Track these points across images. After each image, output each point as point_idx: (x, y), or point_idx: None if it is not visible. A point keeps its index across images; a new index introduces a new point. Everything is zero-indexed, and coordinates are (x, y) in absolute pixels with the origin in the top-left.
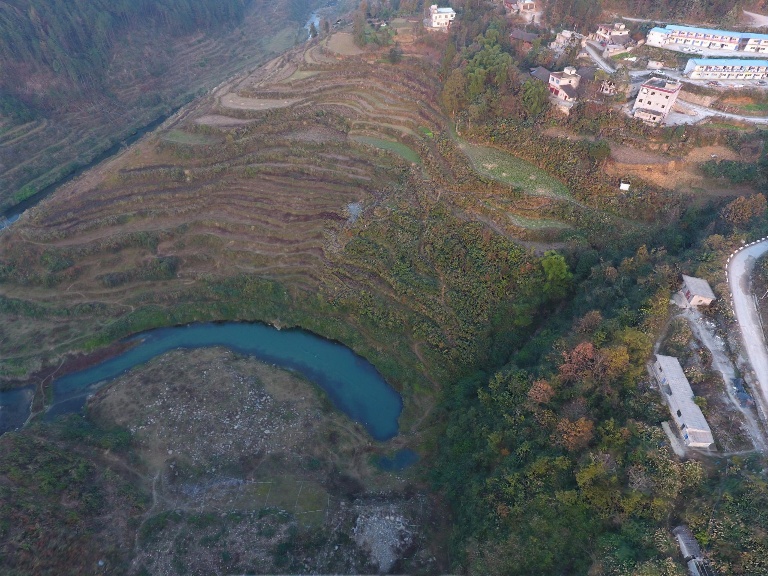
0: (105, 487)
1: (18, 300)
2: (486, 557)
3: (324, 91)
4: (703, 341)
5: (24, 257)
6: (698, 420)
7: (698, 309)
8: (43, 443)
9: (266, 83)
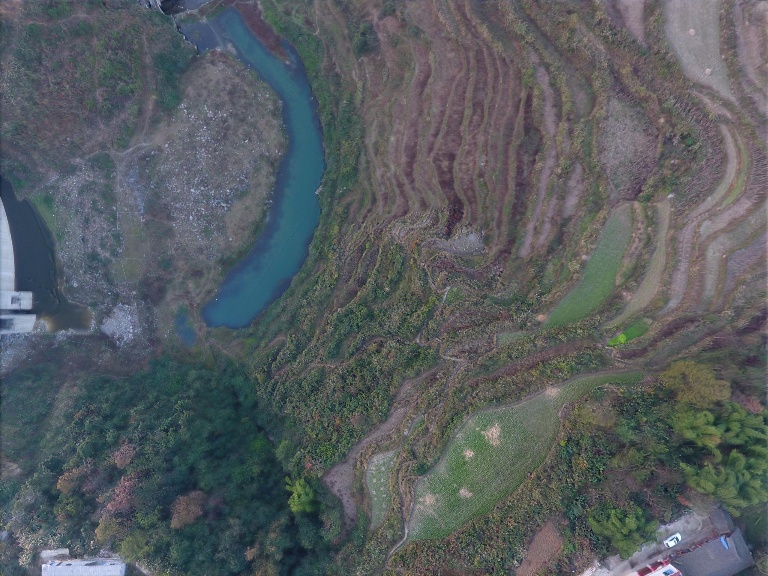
0: (122, 112)
1: None
2: None
3: None
4: None
5: None
6: None
7: None
8: (135, 48)
9: (767, 12)
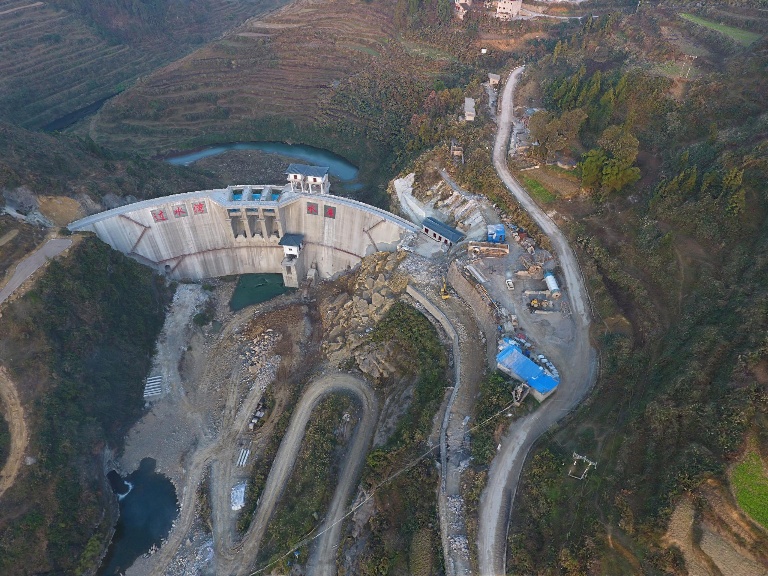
0: None
1: (138, 125)
2: (385, 184)
3: (321, 20)
4: (488, 93)
5: (139, 104)
6: (472, 111)
7: (493, 86)
8: (172, 164)
9: (282, 14)
